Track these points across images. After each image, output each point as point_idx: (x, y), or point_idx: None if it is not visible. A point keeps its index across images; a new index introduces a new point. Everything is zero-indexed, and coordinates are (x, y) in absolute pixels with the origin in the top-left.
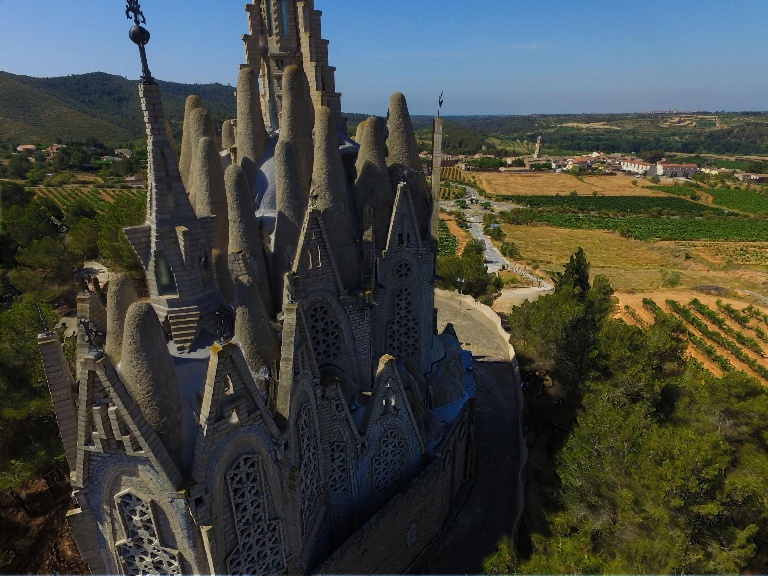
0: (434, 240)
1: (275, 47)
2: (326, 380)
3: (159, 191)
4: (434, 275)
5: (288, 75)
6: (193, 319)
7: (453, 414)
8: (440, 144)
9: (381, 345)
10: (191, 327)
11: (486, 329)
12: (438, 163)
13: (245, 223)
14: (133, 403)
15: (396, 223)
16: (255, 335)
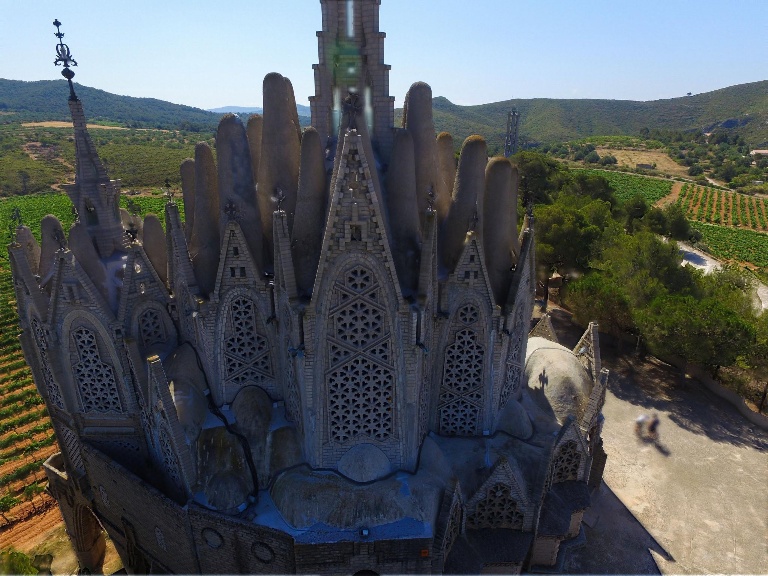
0: (310, 302)
1: None
2: (129, 336)
3: (76, 162)
4: (300, 346)
5: None
6: None
7: (261, 520)
8: (339, 172)
9: None
10: None
11: None
12: None
13: None
14: None
15: None
16: None
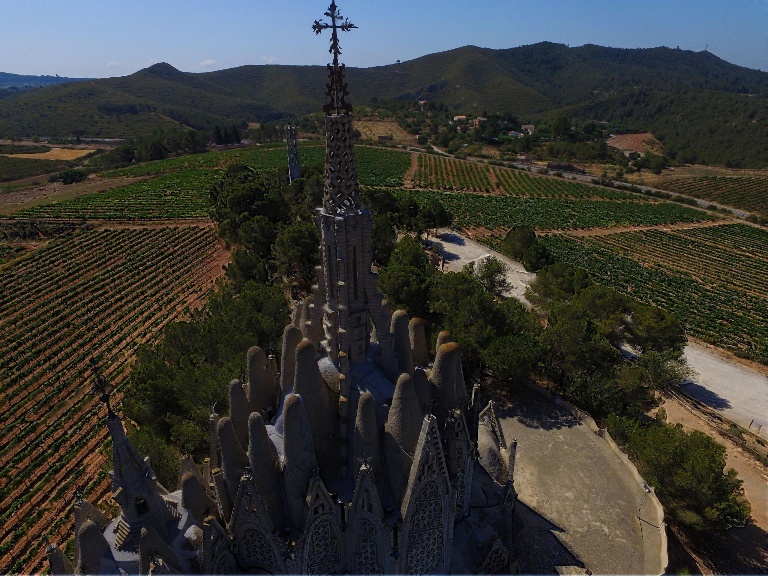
0: (401, 519)
1: (327, 303)
2: None
3: (115, 467)
4: (394, 547)
5: (296, 351)
6: (125, 533)
7: None
8: (423, 442)
9: (351, 564)
10: (123, 537)
11: (638, 569)
12: (418, 457)
13: (224, 456)
14: (62, 575)
15: (359, 491)
16: (143, 563)
